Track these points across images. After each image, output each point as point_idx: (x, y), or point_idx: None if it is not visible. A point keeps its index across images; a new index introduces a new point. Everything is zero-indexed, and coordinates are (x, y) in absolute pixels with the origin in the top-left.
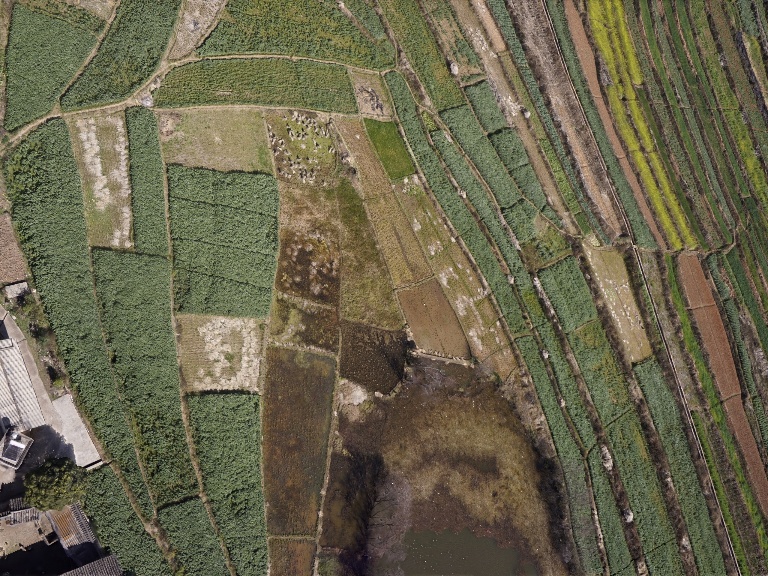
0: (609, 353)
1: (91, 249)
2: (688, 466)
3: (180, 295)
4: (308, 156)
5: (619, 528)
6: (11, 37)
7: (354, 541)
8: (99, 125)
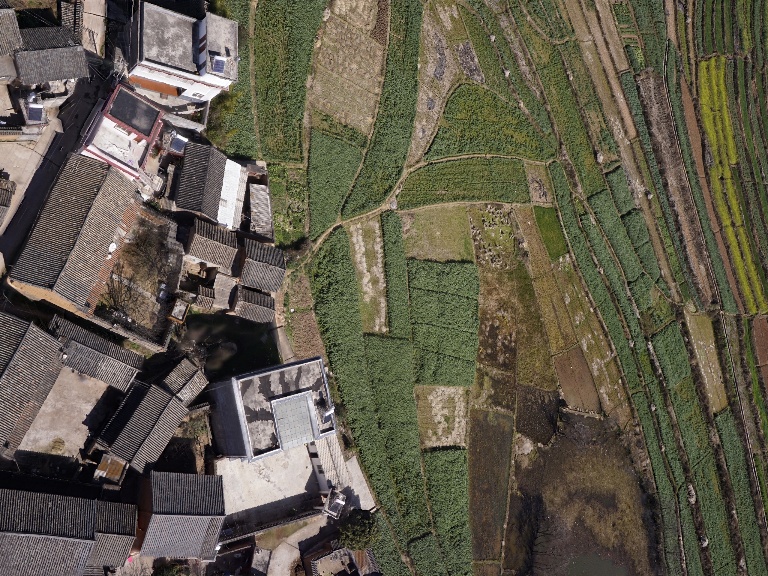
0: (697, 405)
1: (363, 336)
2: (748, 500)
3: (417, 370)
4: (496, 243)
5: (697, 551)
6: (311, 159)
7: (524, 564)
8: (364, 228)
